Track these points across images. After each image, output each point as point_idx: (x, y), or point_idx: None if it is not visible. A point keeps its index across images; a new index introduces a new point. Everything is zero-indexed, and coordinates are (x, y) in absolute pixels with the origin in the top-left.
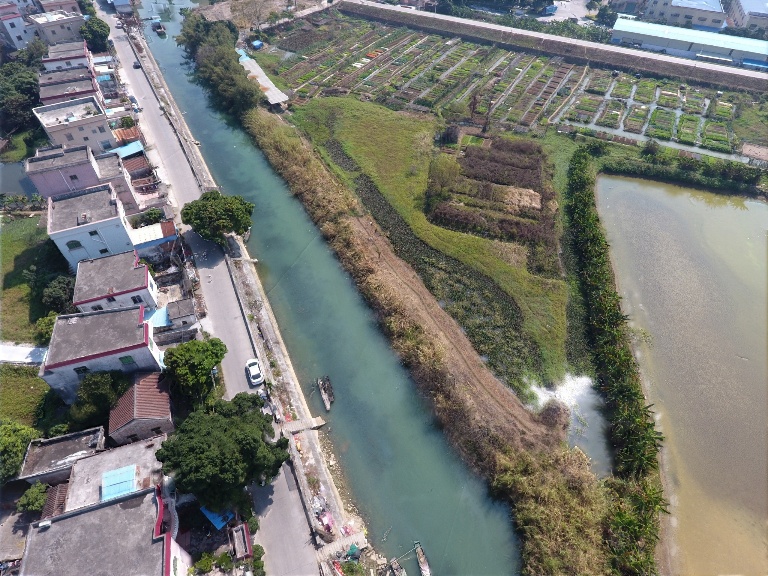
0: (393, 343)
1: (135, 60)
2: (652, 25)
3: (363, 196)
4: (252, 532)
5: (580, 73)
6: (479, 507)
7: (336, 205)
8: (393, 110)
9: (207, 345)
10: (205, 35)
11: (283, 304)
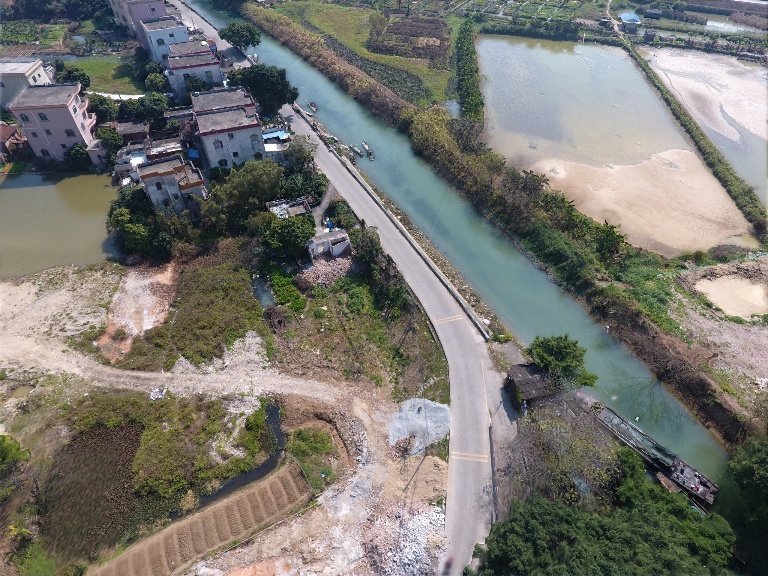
0: (349, 92)
1: None
2: None
3: (327, 43)
4: None
5: None
6: (393, 134)
7: (310, 41)
8: (345, 7)
9: None
10: None
11: None
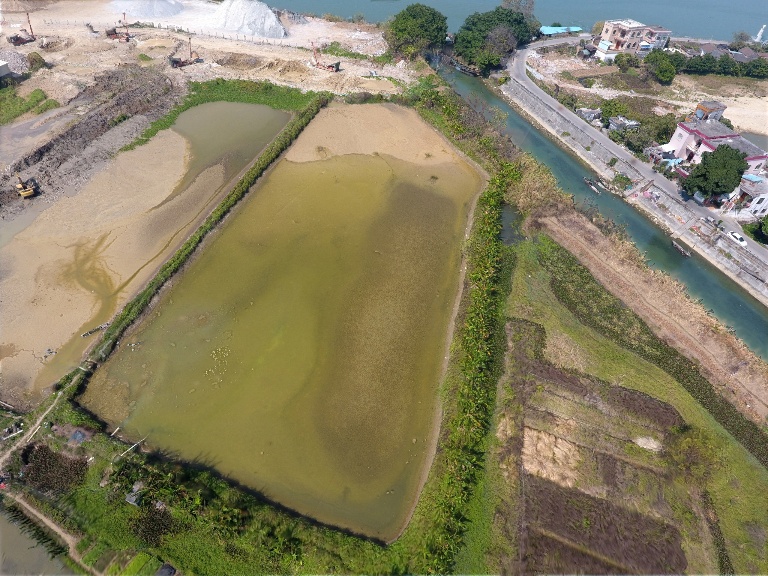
0: None
1: None
2: None
3: None
4: None
5: None
6: None
7: None
8: None
9: None
10: None
11: (762, 313)
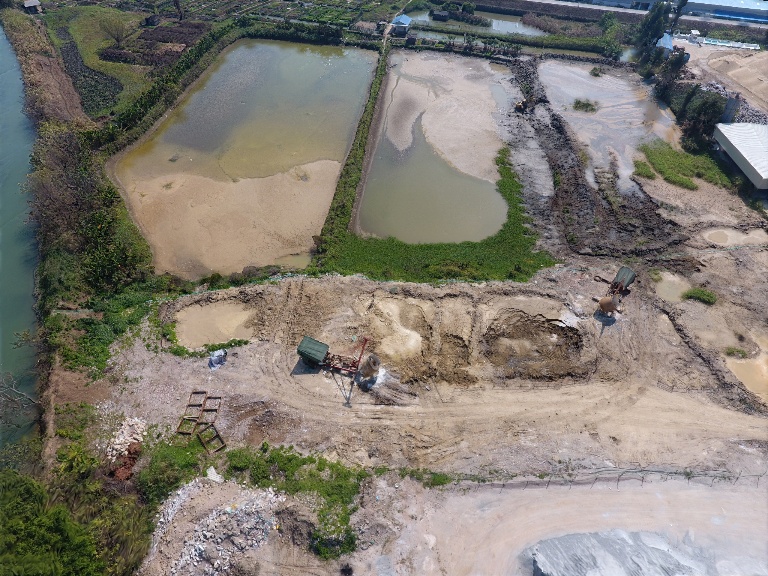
0: None
1: None
2: None
3: (64, 50)
4: None
5: None
6: (32, 148)
7: None
8: (124, 11)
9: None
10: None
11: None
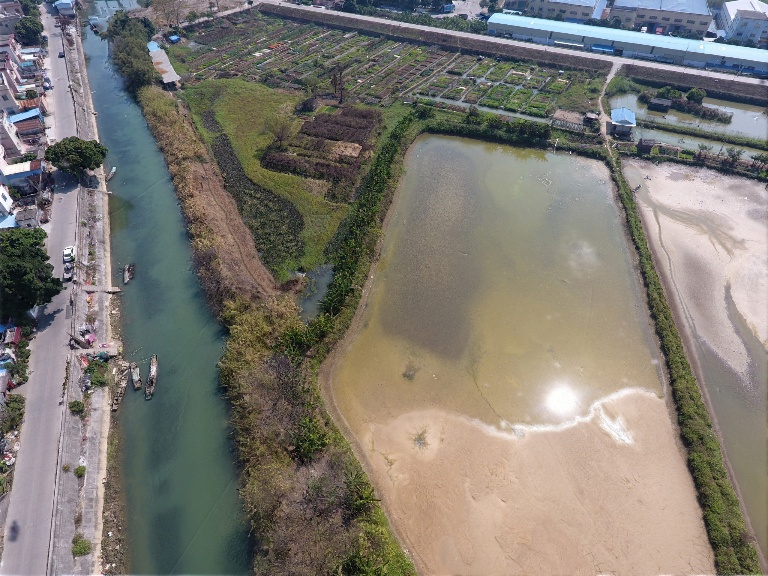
0: None
1: (61, 51)
2: (522, 18)
3: (216, 149)
4: (24, 334)
5: (449, 58)
6: (210, 337)
7: (184, 153)
8: (271, 88)
9: (29, 230)
10: (121, 29)
11: (121, 221)
